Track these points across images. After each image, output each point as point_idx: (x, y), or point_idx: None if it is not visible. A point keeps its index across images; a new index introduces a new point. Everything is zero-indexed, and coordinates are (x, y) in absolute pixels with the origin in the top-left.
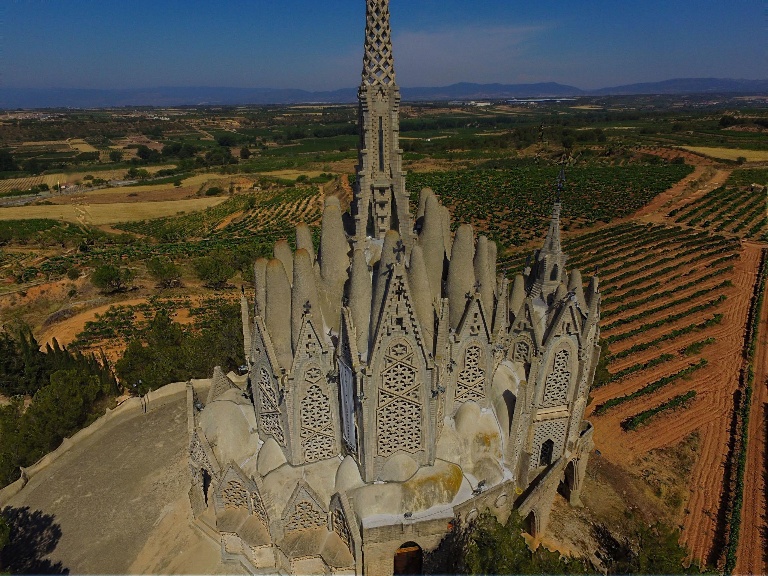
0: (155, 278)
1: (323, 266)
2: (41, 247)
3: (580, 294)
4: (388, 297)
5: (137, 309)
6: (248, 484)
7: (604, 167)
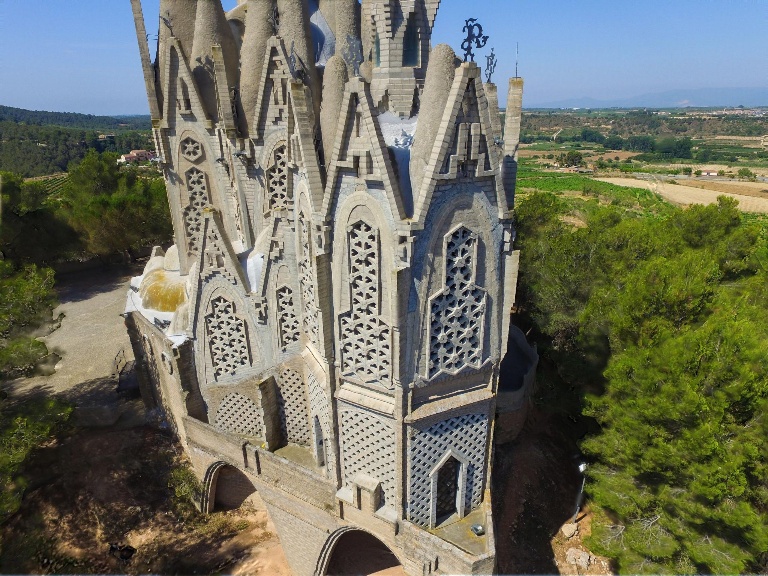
0: (584, 218)
1: None
2: None
3: (423, 114)
4: None
5: None
6: None
7: None
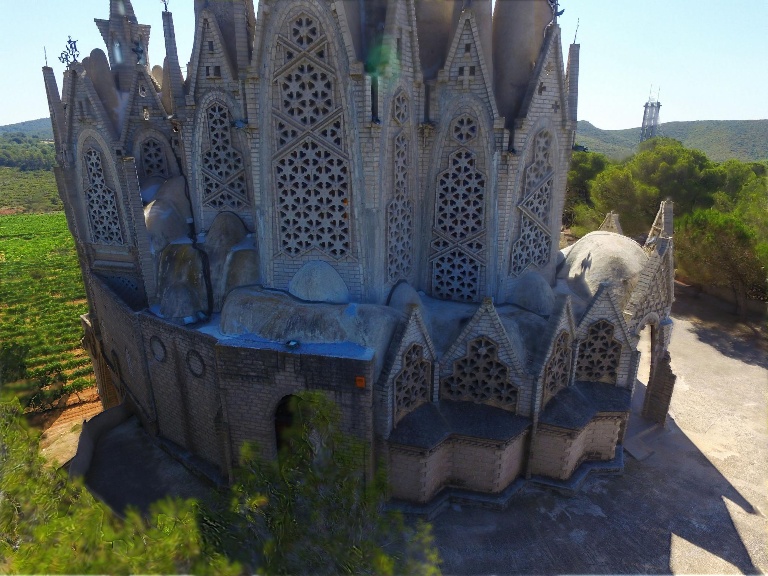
0: None
1: None
2: None
3: None
4: None
5: None
6: None
7: None
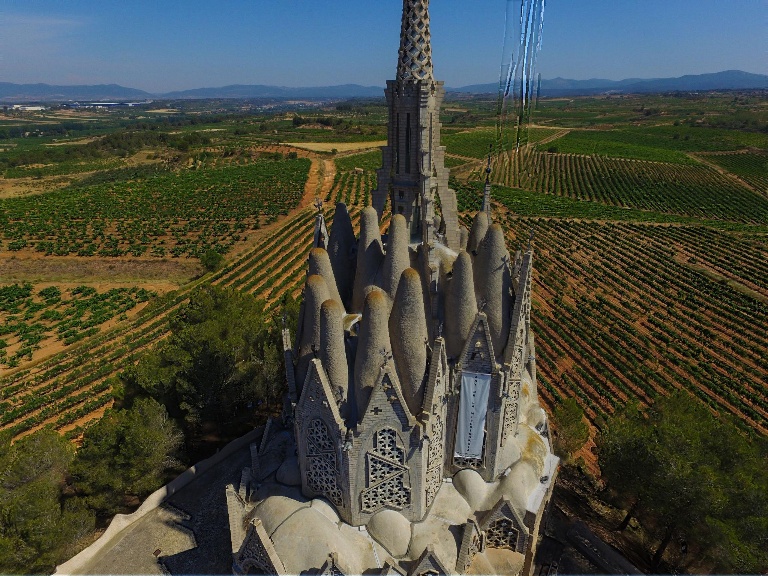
0: None
1: None
2: None
3: None
4: (525, 286)
5: None
6: (405, 573)
7: (239, 167)
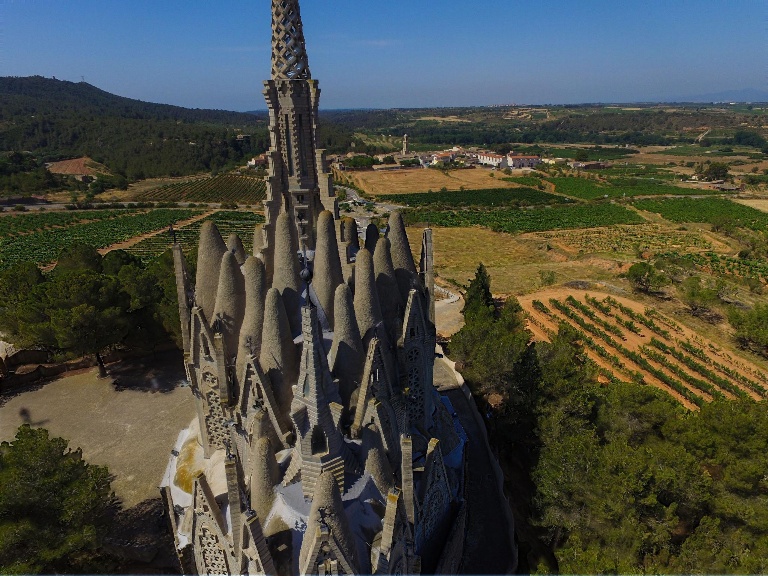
0: (682, 297)
1: None
2: (726, 242)
3: (310, 521)
4: None
5: (625, 311)
6: None
7: None
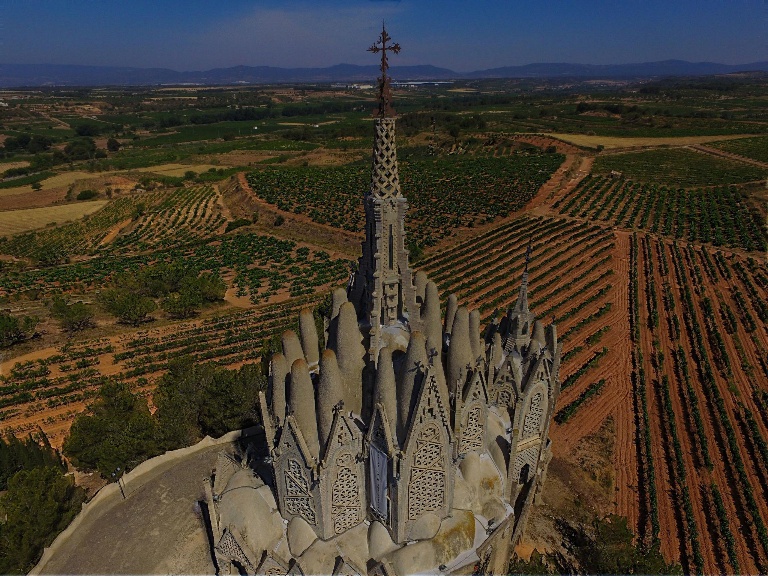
0: (62, 322)
1: (340, 357)
2: None
3: (543, 341)
4: (423, 394)
5: (49, 362)
6: (287, 568)
7: (491, 158)
